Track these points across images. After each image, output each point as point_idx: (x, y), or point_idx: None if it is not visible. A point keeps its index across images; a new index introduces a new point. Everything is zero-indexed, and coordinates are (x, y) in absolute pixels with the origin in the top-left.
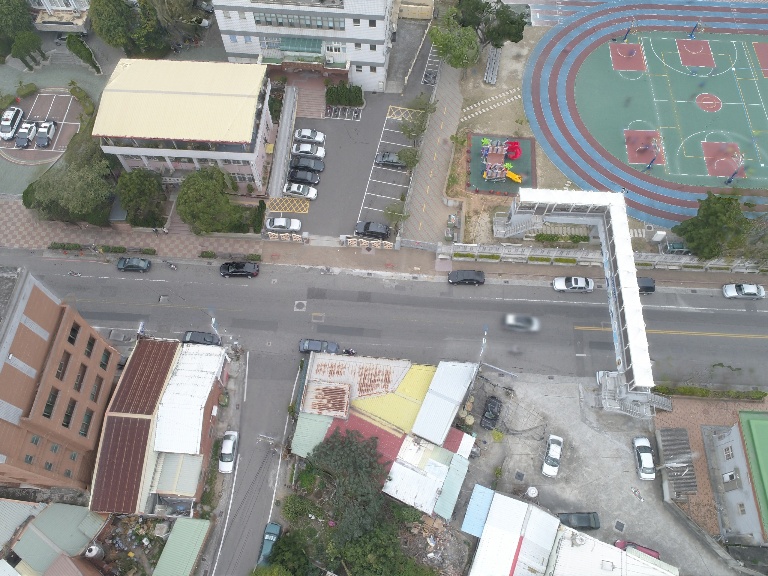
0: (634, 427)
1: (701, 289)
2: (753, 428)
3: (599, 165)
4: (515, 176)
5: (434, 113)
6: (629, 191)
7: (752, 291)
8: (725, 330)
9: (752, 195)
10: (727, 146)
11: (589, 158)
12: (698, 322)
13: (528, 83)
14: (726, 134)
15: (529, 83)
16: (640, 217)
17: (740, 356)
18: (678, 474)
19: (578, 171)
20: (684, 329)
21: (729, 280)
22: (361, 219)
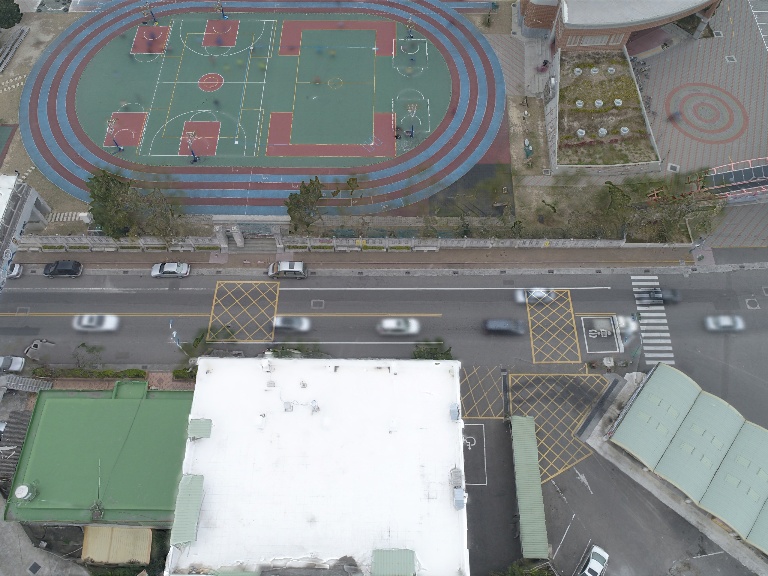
0: (5, 412)
1: (134, 270)
2: (45, 407)
3: (72, 149)
4: None
5: None
6: (90, 174)
7: (171, 269)
8: (138, 310)
9: (213, 173)
10: (210, 125)
11: (65, 143)
12: (115, 303)
13: (37, 70)
14: (214, 113)
15: (38, 70)
16: (89, 200)
17: (142, 335)
18: (5, 457)
19: (47, 156)
20: (97, 311)
21: (164, 259)
22: None
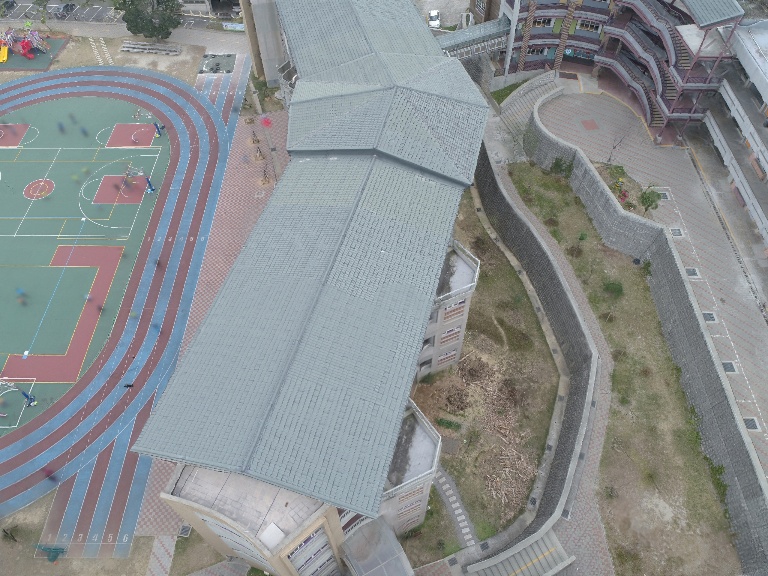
0: None
1: None
2: None
3: None
4: (6, 57)
5: (106, 25)
6: None
7: None
8: None
9: None
10: None
11: (8, 101)
12: None
13: (117, 69)
14: None
15: (117, 70)
16: None
17: None
18: None
19: None
20: None
21: None
22: (22, 5)
